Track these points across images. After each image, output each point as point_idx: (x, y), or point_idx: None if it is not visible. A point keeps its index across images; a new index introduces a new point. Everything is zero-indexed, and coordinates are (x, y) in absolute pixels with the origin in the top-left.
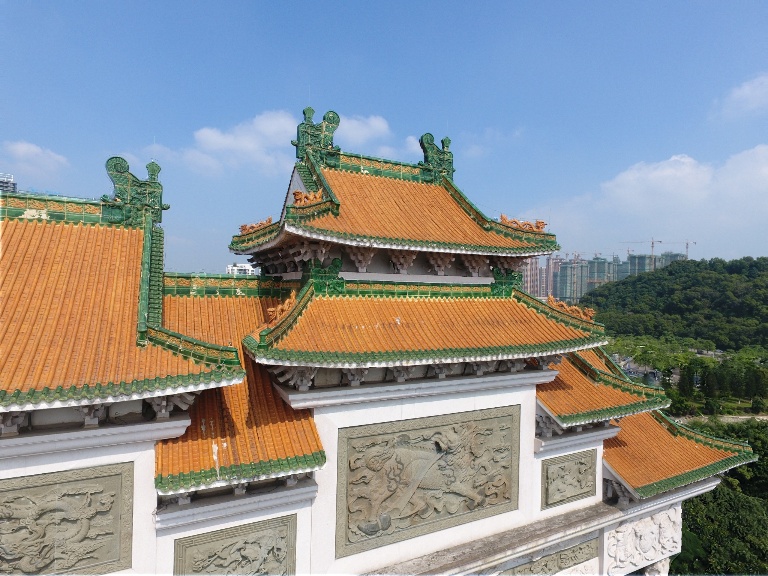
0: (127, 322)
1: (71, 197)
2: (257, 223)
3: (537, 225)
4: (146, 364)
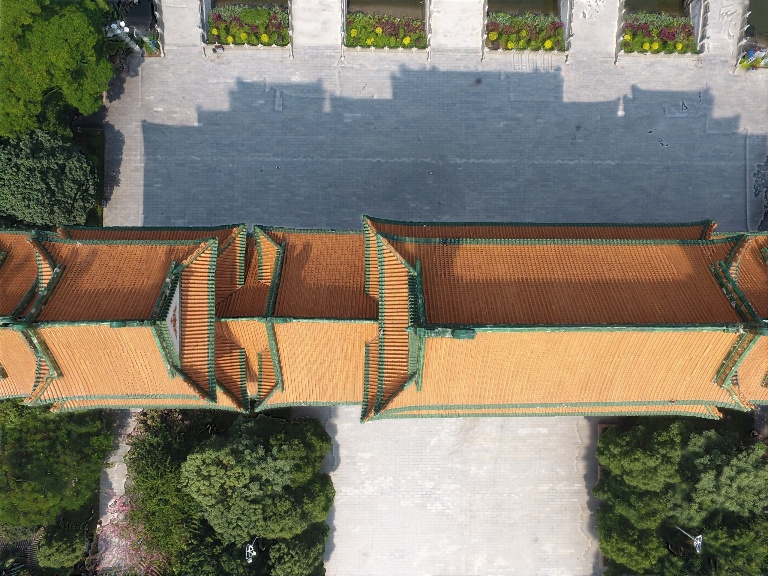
0: (763, 372)
1: None
2: None
3: None
4: (760, 394)
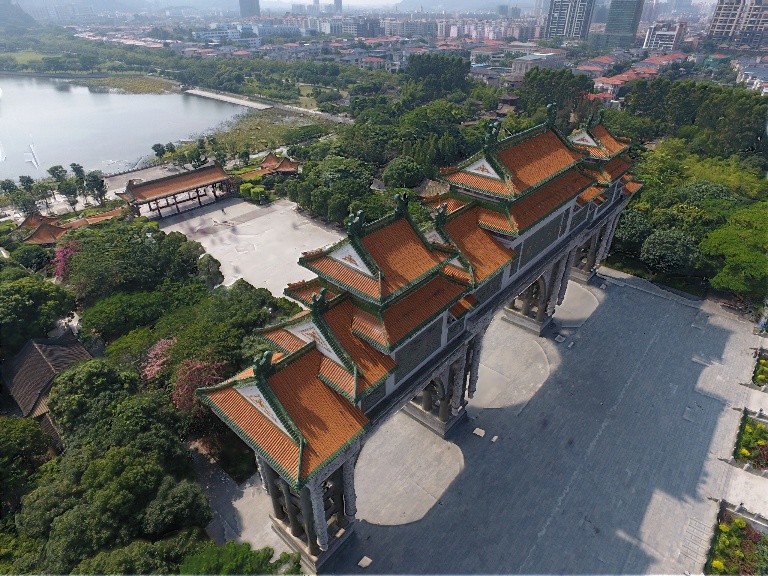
0: None
1: (450, 213)
2: (445, 244)
3: (307, 253)
4: None
